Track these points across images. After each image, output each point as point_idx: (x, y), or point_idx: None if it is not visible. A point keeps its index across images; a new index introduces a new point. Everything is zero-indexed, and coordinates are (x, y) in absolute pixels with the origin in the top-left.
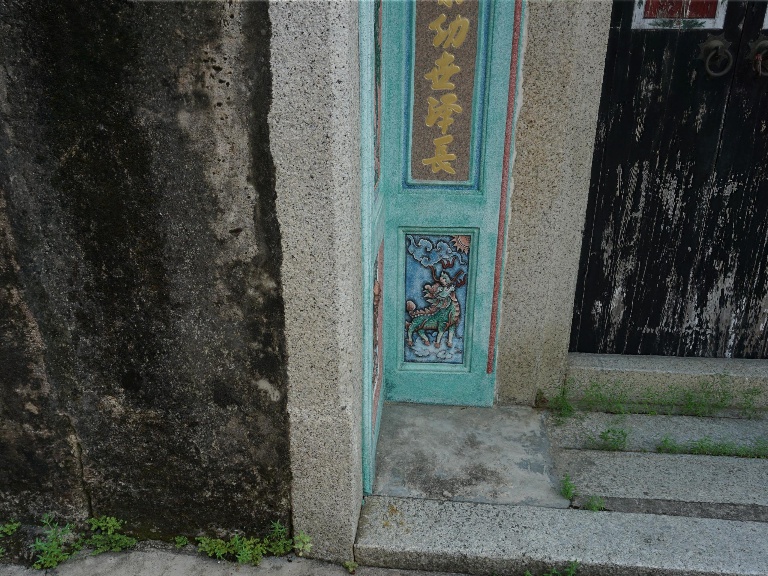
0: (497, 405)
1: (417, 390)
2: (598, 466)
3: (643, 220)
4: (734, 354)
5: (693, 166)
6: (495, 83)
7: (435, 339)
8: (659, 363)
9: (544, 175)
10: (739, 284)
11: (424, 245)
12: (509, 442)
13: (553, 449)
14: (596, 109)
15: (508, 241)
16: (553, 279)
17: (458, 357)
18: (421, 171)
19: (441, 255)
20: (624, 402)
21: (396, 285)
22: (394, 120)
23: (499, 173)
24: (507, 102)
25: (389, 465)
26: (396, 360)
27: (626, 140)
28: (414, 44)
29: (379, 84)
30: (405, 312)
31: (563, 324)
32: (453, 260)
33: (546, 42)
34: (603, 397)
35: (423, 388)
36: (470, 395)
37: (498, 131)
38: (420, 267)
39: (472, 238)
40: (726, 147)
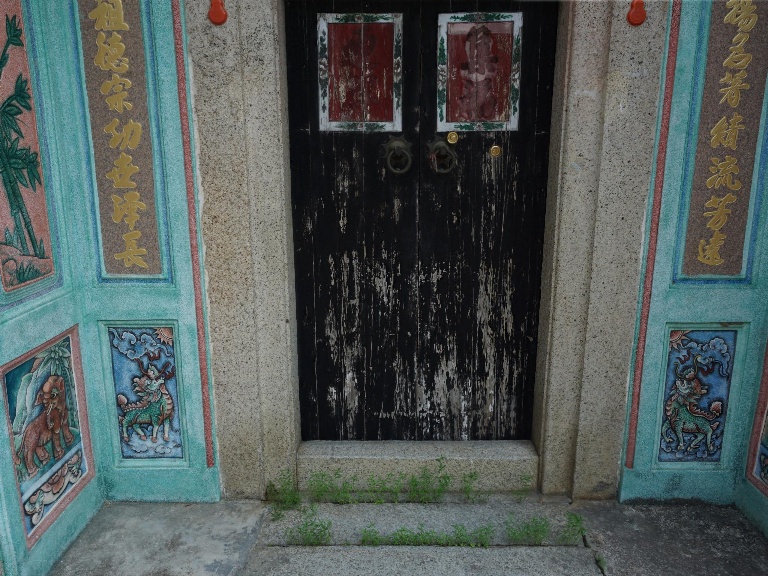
0: (225, 500)
1: (139, 488)
2: (290, 564)
3: (361, 307)
4: (471, 436)
5: (398, 255)
6: (172, 182)
7: (151, 433)
8: (390, 449)
9: (236, 267)
10: (461, 367)
11: (128, 338)
12: (213, 541)
13: (256, 547)
14: (280, 205)
15: (211, 332)
16: (266, 368)
17: (177, 451)
18: (114, 265)
19: (146, 347)
20: (357, 491)
21: (103, 379)
22: (79, 217)
23: (188, 266)
24: (186, 199)
25: (65, 575)
26: (113, 457)
27: (332, 232)
28: (92, 146)
29: (33, 185)
30: (117, 406)
31: (282, 413)
32: (159, 352)
33: (217, 144)
34: (334, 486)
35: (144, 485)
36: (194, 491)
37: (181, 226)
38: (126, 360)
39: (174, 330)
40: (425, 237)
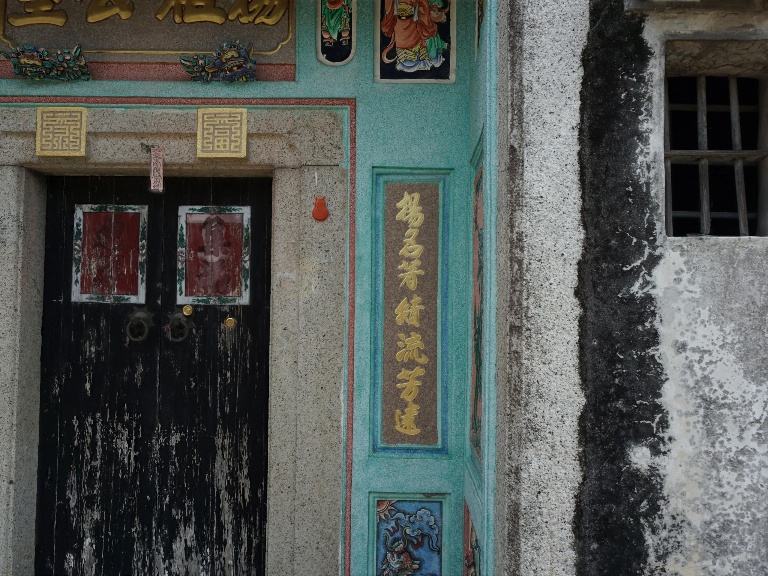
0: None
1: None
2: None
3: (102, 469)
4: None
5: (140, 418)
6: None
7: None
8: None
9: None
10: (200, 534)
11: None
12: None
13: None
14: (12, 368)
15: None
16: None
17: None
18: None
19: None
20: None
21: None
22: None
23: None
24: None
25: None
26: None
27: (78, 394)
28: None
29: None
30: None
31: None
32: None
33: None
34: None
35: None
36: None
37: None
38: None
39: None
40: (165, 401)
